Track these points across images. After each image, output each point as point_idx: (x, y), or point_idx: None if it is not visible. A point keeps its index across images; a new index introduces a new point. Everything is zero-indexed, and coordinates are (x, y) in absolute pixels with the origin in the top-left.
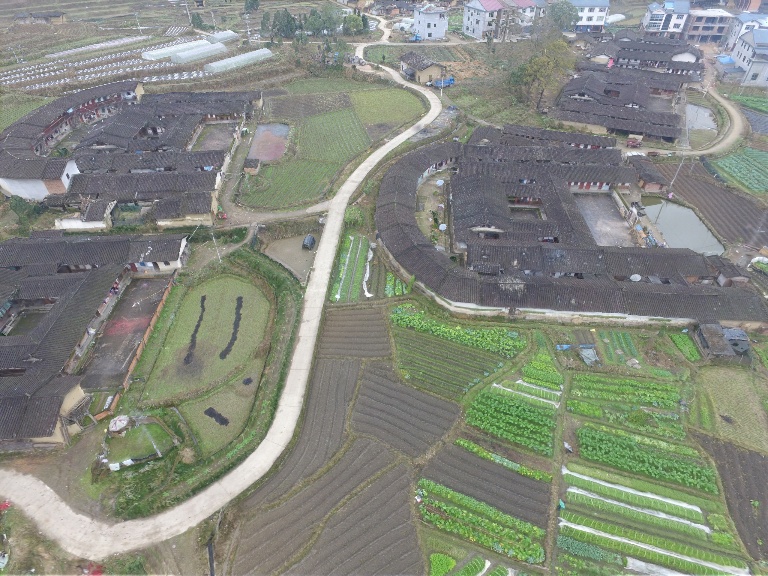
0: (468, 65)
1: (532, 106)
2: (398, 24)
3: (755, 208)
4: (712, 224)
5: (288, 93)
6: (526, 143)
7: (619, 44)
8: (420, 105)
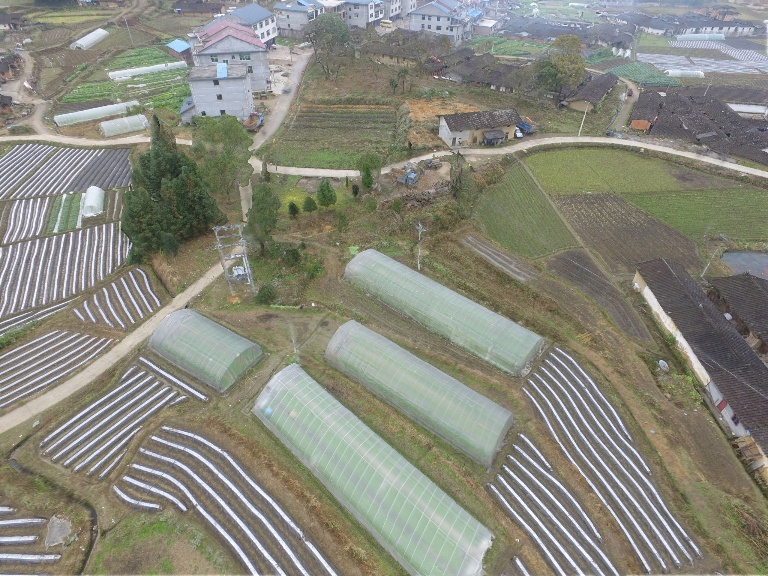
0: (432, 107)
1: (550, 107)
2: (113, 125)
3: (709, 89)
4: (746, 101)
5: (580, 249)
6: (677, 120)
7: (380, 43)
8: (595, 150)
